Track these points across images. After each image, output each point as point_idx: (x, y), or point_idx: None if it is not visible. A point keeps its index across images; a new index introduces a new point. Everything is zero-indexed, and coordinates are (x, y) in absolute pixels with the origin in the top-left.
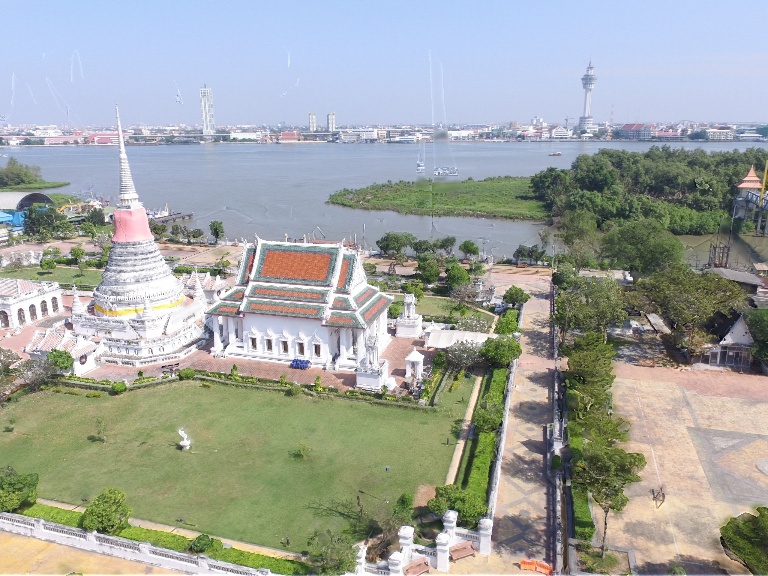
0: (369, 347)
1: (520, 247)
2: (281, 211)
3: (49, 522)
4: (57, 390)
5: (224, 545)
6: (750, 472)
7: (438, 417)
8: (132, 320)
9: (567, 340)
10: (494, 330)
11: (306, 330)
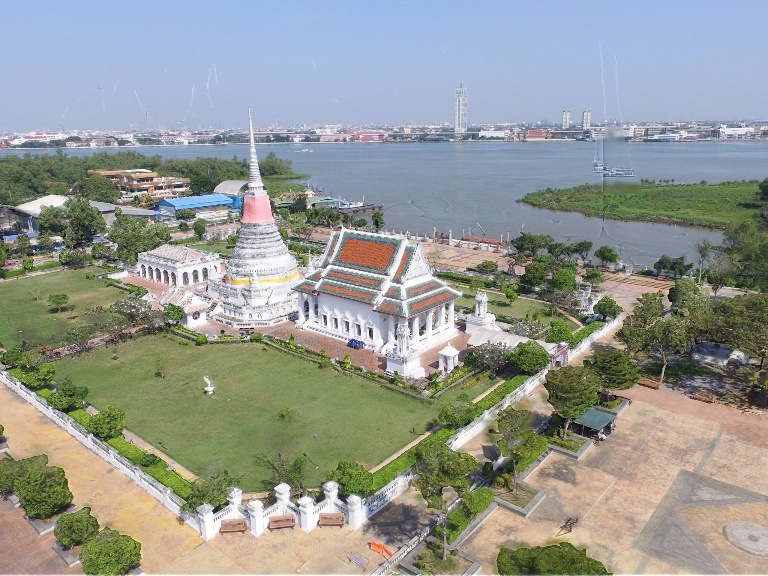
0: (398, 335)
1: (663, 258)
2: (464, 207)
3: (77, 422)
4: (164, 335)
5: (169, 467)
6: (709, 531)
7: (429, 409)
8: (244, 289)
9: (637, 360)
10: (546, 337)
11: (363, 313)
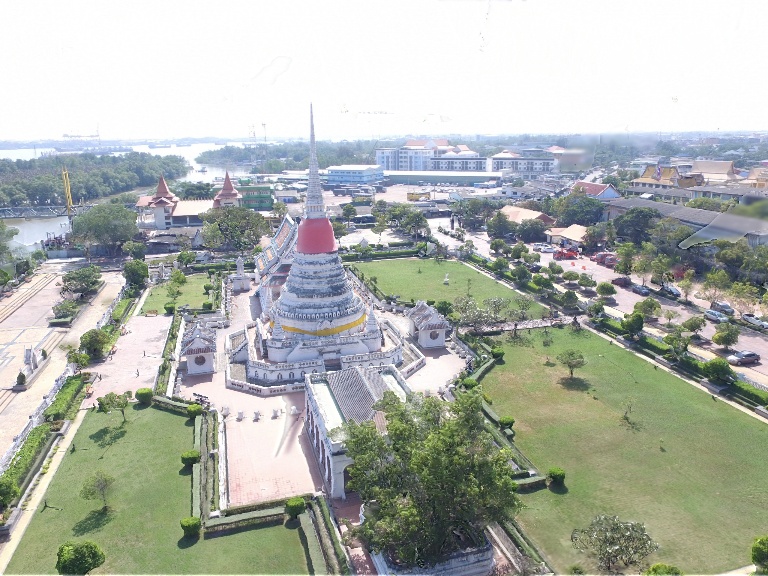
0: None
1: (17, 263)
2: None
3: None
4: None
5: None
6: None
7: None
8: None
9: None
10: None
11: None
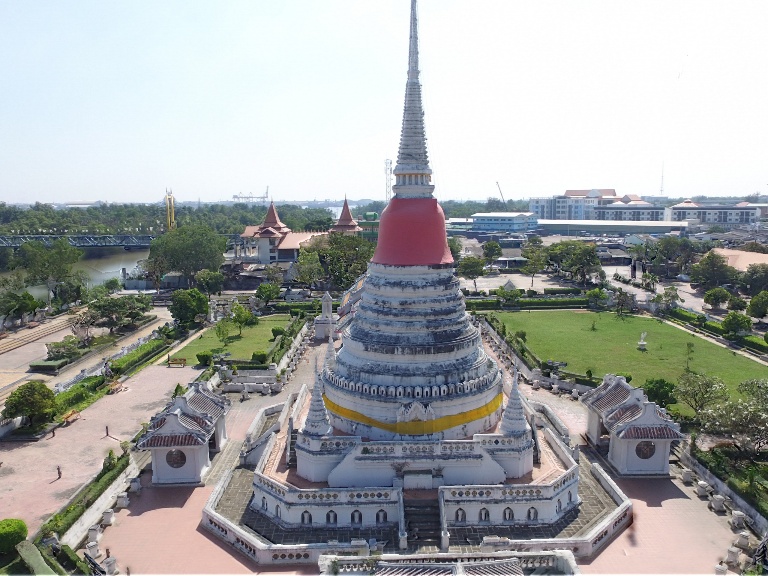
0: None
1: (63, 288)
2: None
3: None
4: None
5: None
6: None
7: (500, 315)
8: None
9: None
10: None
11: None
